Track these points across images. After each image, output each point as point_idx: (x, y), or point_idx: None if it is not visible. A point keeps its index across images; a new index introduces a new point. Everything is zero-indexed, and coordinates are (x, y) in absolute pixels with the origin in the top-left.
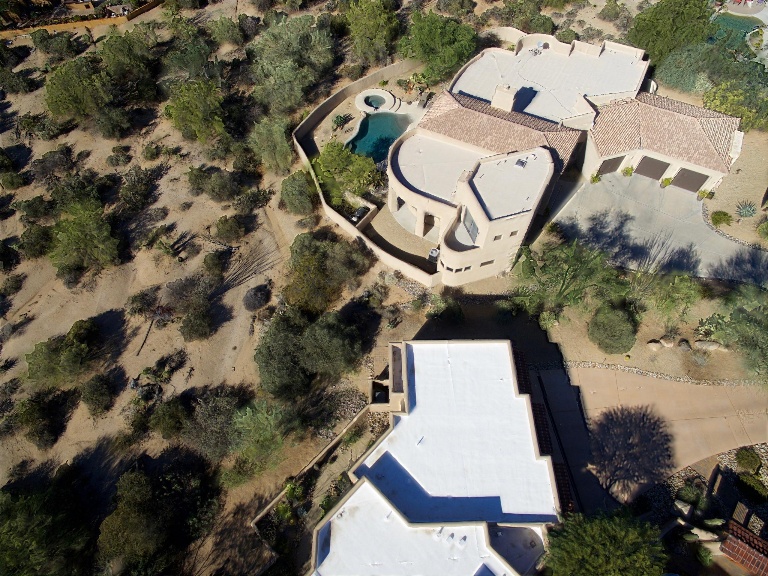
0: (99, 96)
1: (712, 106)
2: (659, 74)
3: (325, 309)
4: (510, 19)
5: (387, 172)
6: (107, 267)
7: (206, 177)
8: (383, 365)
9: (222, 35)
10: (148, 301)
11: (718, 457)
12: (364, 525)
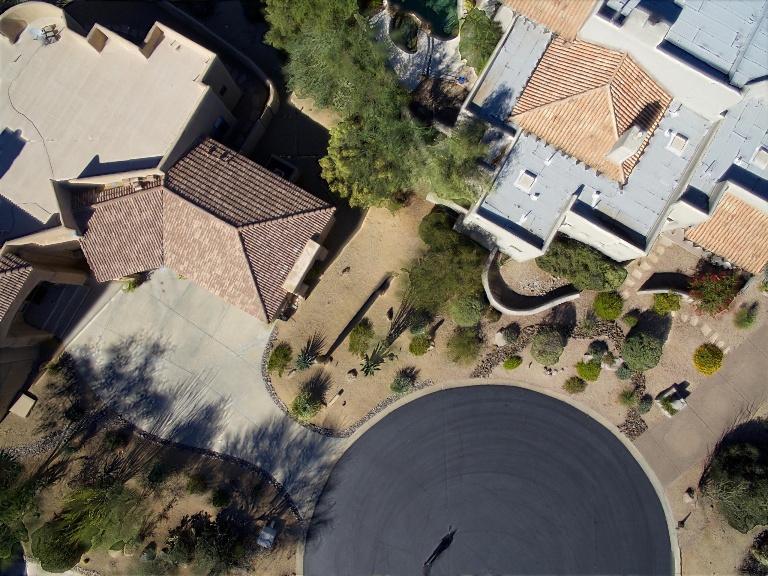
0: None
1: None
2: (293, 64)
3: None
4: None
5: None
6: None
7: None
8: None
9: None
10: None
11: None
12: None
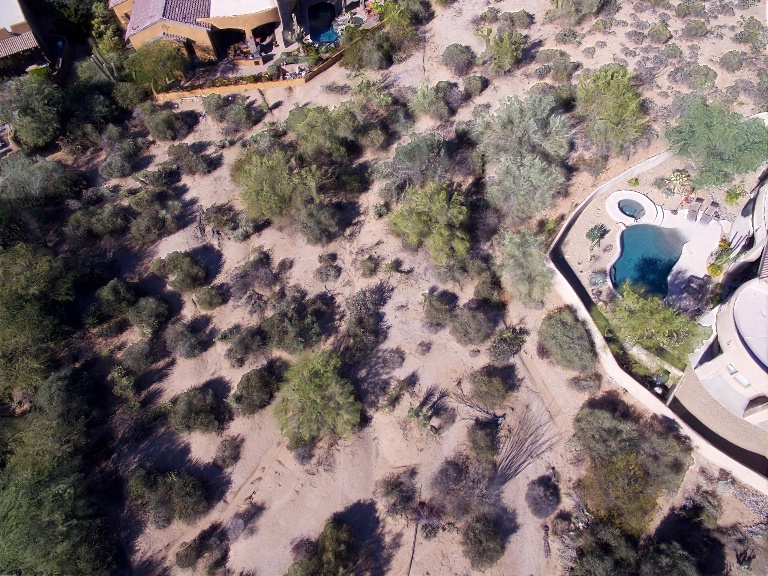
0: (306, 194)
1: None
2: None
3: (644, 527)
4: (766, 97)
5: (731, 347)
6: (344, 435)
7: (447, 310)
8: None
9: (421, 107)
10: (407, 495)
11: None
12: None
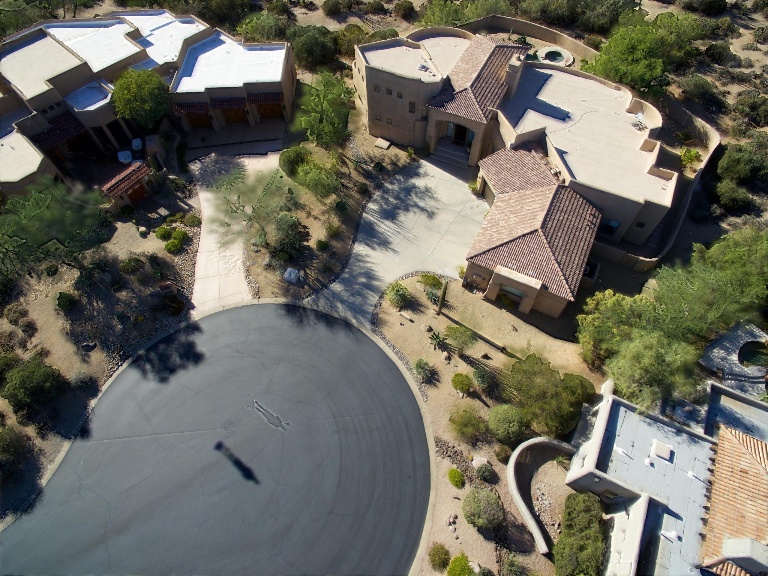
0: None
1: (605, 292)
2: None
3: (342, 53)
4: None
5: None
6: None
7: None
8: (300, 78)
9: None
10: None
11: (199, 209)
12: (191, 32)
